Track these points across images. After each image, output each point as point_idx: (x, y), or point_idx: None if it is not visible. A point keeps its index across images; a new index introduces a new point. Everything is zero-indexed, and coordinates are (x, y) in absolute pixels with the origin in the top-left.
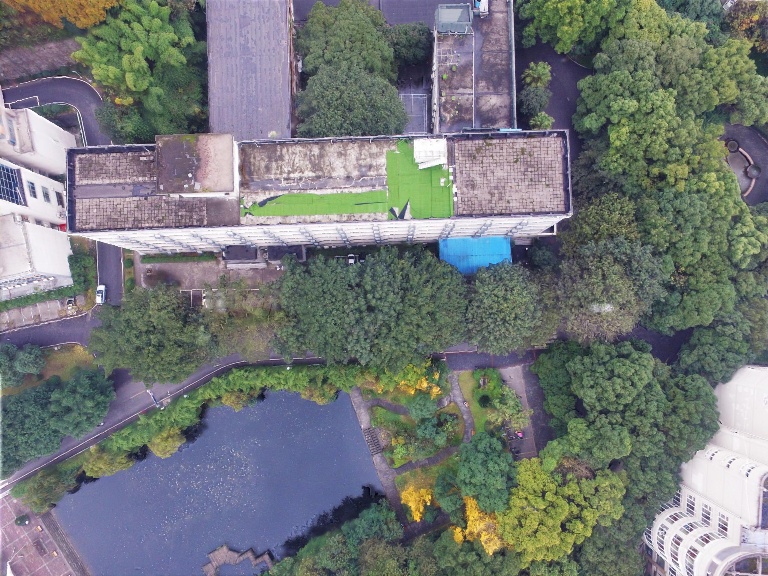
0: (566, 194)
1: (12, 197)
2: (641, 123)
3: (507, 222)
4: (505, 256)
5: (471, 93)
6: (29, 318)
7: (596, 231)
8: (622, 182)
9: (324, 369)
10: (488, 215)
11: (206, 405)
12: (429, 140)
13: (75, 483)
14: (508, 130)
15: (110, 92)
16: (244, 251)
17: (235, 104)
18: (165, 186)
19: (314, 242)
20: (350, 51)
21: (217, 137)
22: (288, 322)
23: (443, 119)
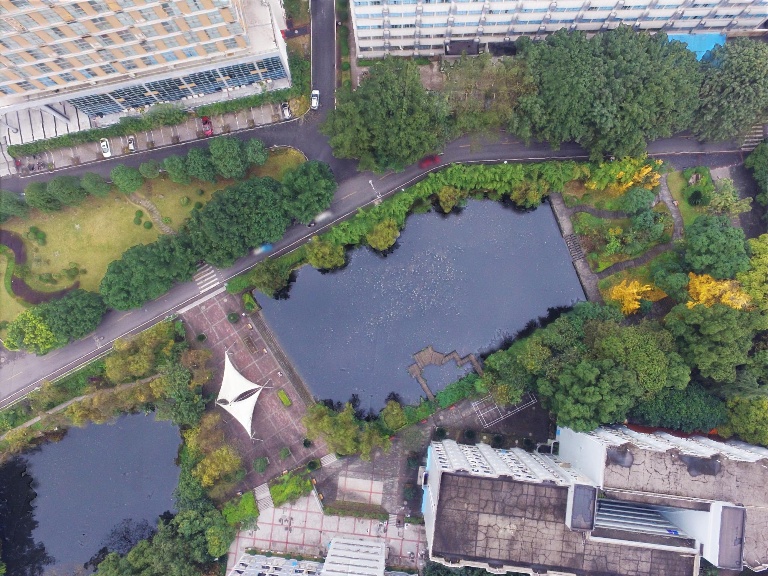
0: None
1: None
2: None
3: None
4: None
5: None
6: (243, 122)
7: None
8: None
9: (539, 164)
10: None
11: (409, 212)
12: None
13: (287, 281)
14: None
15: None
16: (466, 46)
17: None
18: None
19: (543, 30)
20: None
21: None
22: (533, 90)
23: None
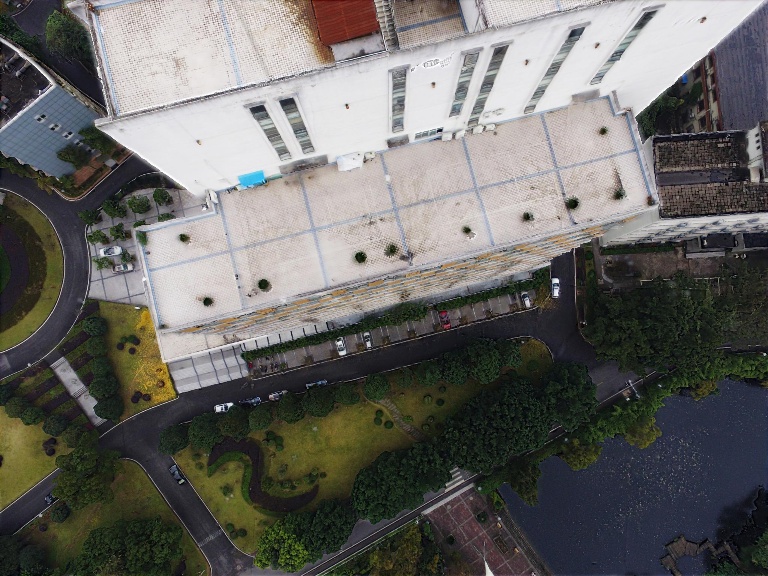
0: None
1: None
2: None
3: None
4: None
5: None
6: (481, 313)
7: None
8: None
9: None
10: None
11: None
12: None
13: None
14: None
15: None
16: (722, 239)
17: (744, 93)
18: None
19: None
20: None
21: None
22: None
23: None
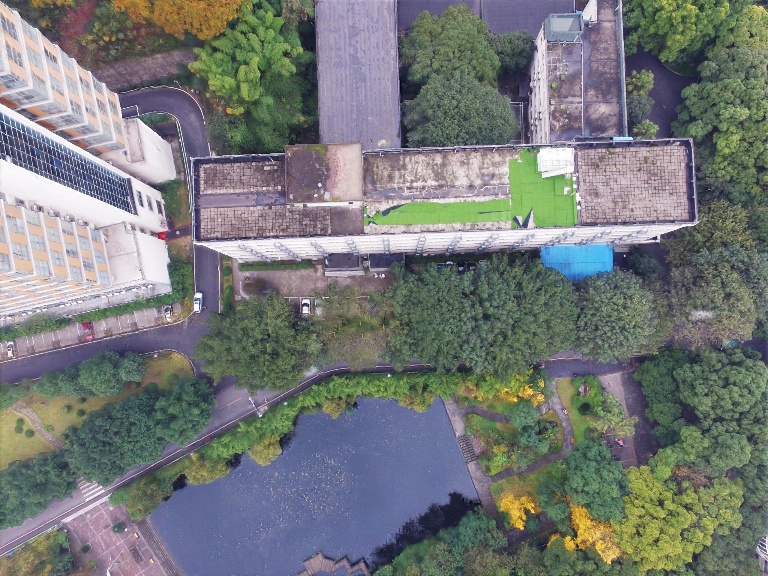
0: (690, 202)
1: (125, 206)
2: (752, 131)
3: (626, 230)
4: (607, 263)
5: (580, 101)
6: (126, 326)
7: (707, 239)
8: (730, 190)
9: (424, 376)
10: (612, 224)
11: (300, 412)
12: (555, 149)
13: (172, 490)
14: (619, 138)
15: (221, 102)
16: (346, 259)
17: (345, 113)
18: (295, 196)
19: (420, 250)
20: (459, 60)
21: (346, 147)
22: (402, 330)
23: (552, 127)
